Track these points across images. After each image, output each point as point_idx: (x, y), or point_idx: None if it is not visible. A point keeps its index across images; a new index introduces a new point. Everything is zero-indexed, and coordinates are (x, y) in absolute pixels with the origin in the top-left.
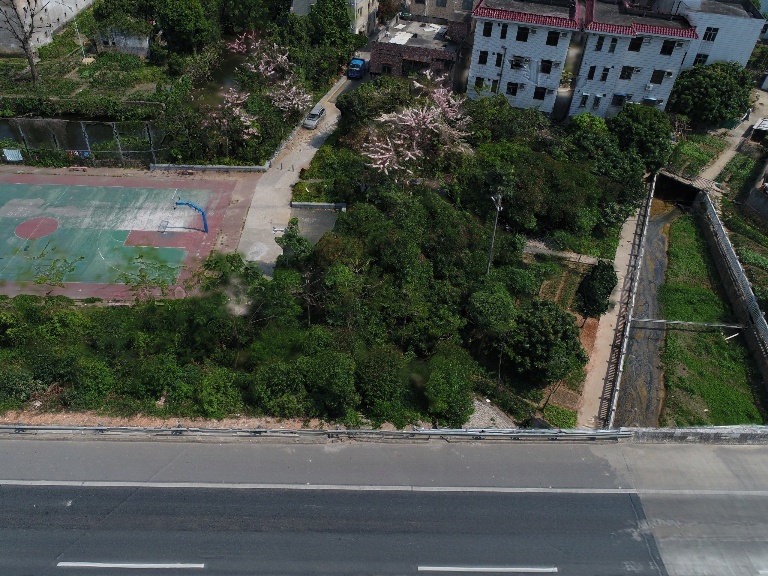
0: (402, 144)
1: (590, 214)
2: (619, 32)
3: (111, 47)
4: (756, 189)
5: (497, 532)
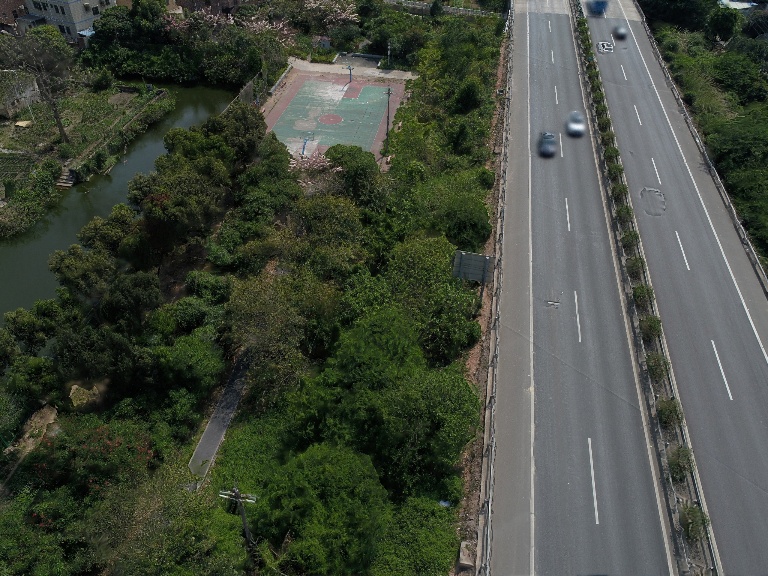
0: (340, 8)
1: (388, 3)
2: None
3: (17, 106)
4: None
5: None
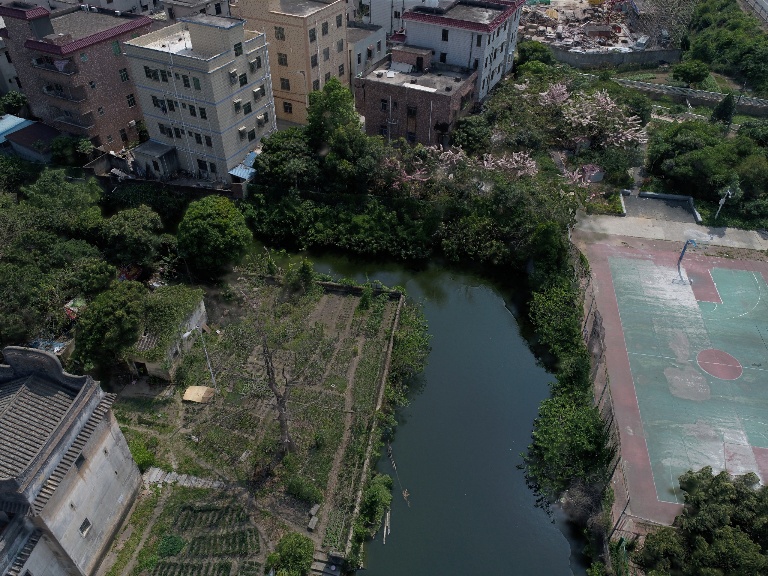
0: None
1: None
2: (523, 2)
3: (180, 354)
4: (579, 54)
5: None
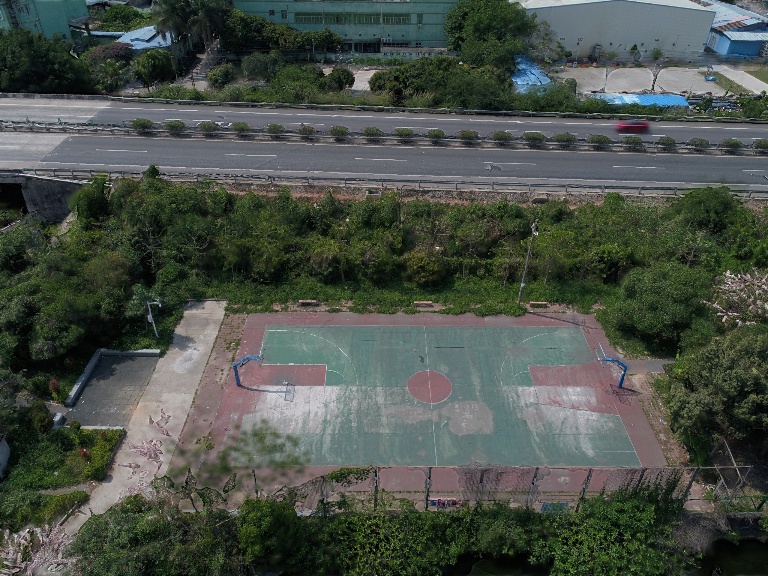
0: None
1: None
2: None
3: None
4: None
5: (110, 156)
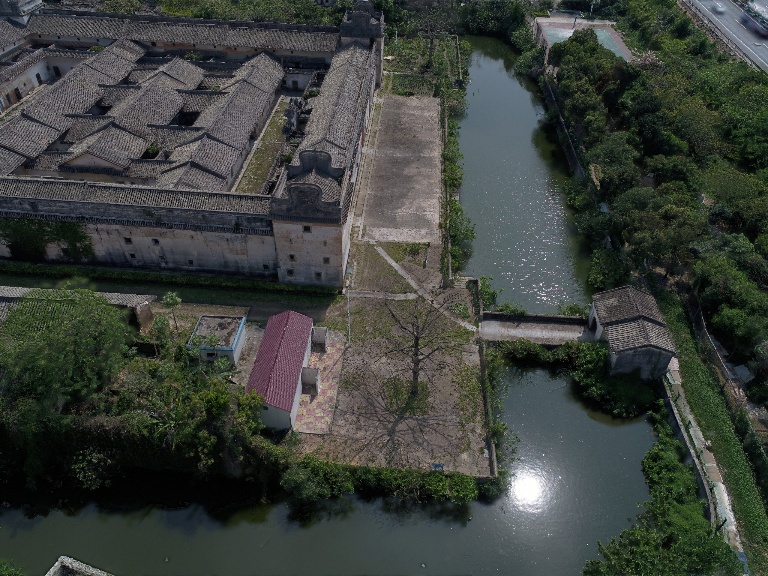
0: None
1: None
2: None
3: None
4: None
5: None
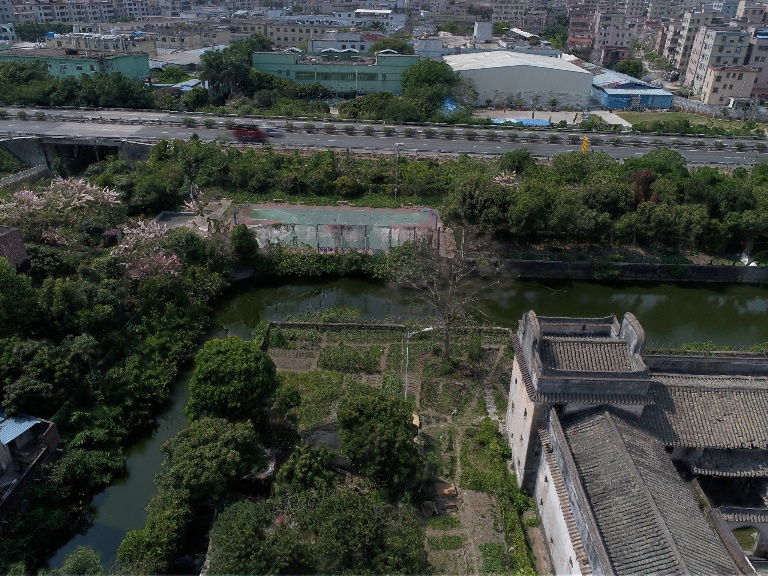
0: None
1: None
2: None
3: None
4: None
5: None
